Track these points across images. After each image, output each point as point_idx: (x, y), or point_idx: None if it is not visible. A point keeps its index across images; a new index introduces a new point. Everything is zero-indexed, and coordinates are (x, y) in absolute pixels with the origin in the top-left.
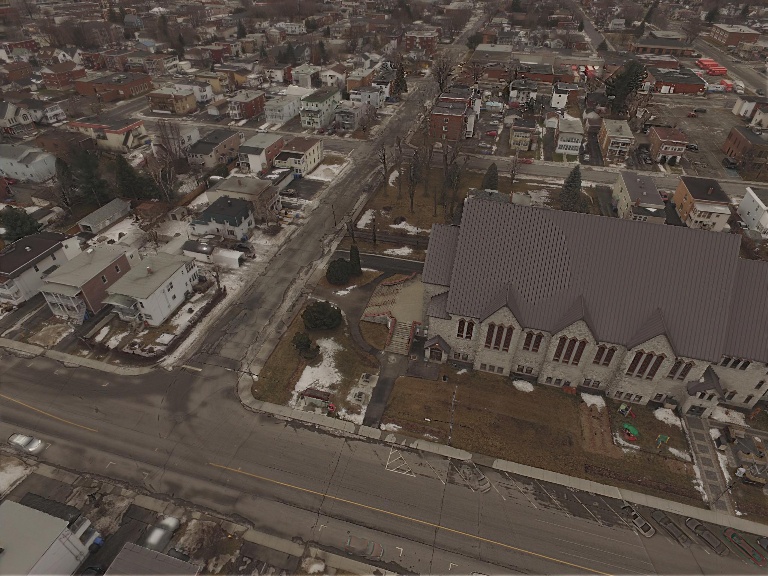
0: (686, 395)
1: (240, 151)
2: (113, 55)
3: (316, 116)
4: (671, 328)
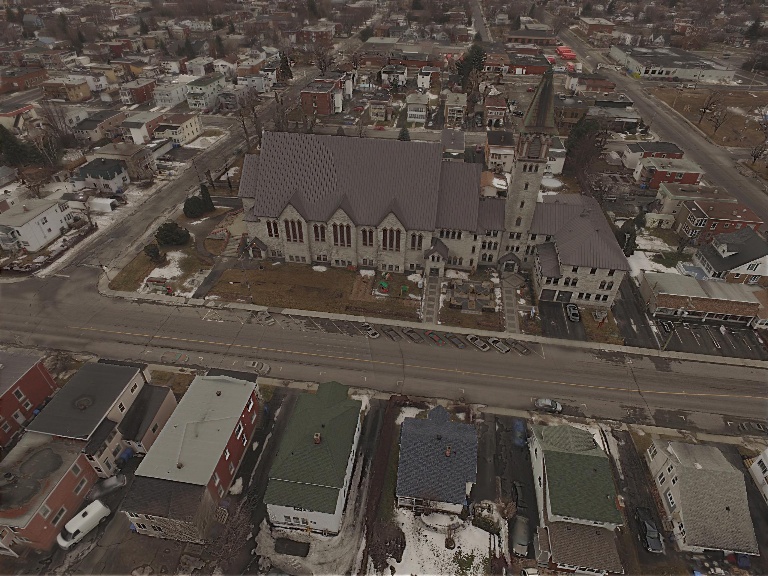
0: None
1: (122, 126)
2: None
3: (201, 98)
4: (403, 211)
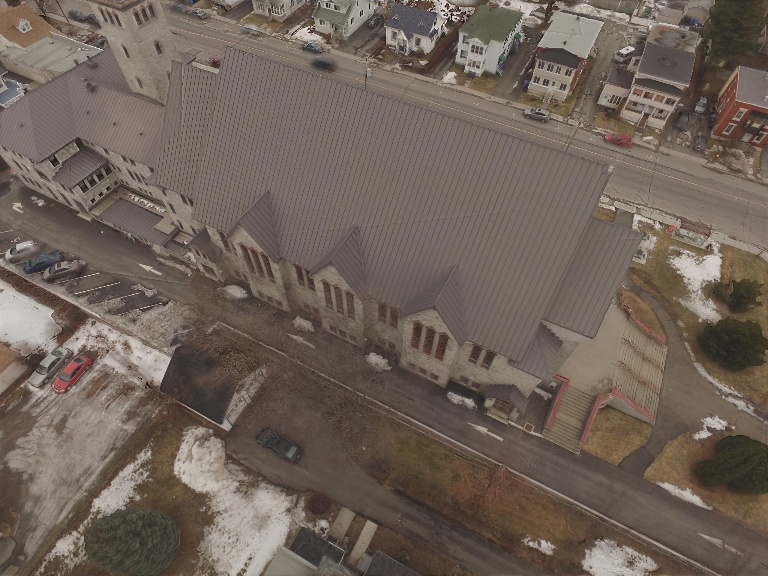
0: None
1: None
2: None
3: None
4: None
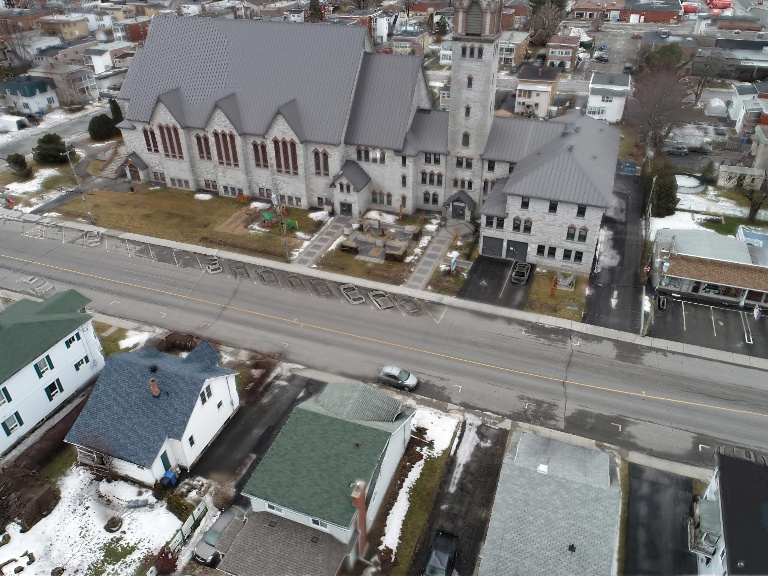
0: None
1: (84, 53)
2: None
3: None
4: (302, 116)
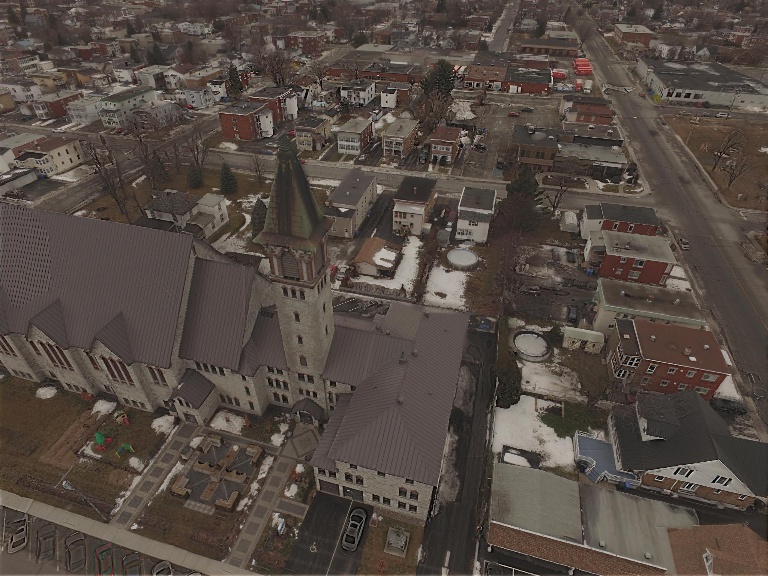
0: None
1: None
2: None
3: (114, 116)
4: (130, 333)
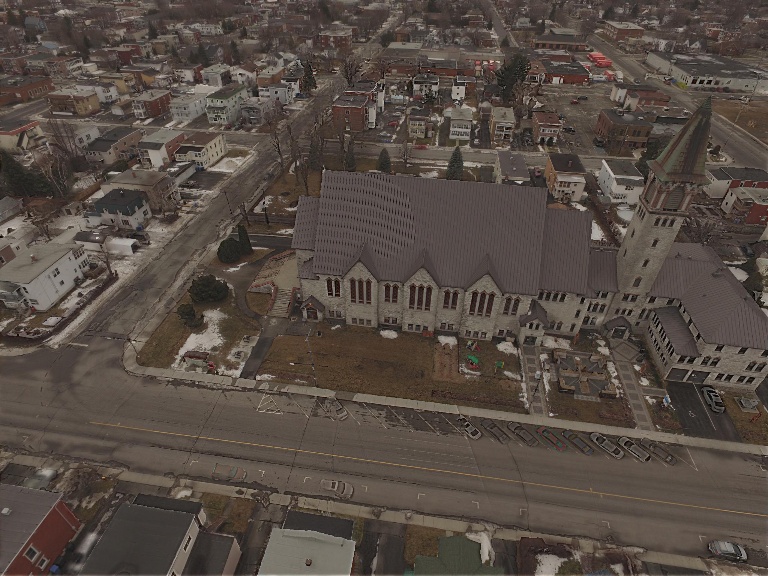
0: (520, 328)
1: (139, 147)
2: (10, 58)
3: (222, 112)
4: (498, 270)
